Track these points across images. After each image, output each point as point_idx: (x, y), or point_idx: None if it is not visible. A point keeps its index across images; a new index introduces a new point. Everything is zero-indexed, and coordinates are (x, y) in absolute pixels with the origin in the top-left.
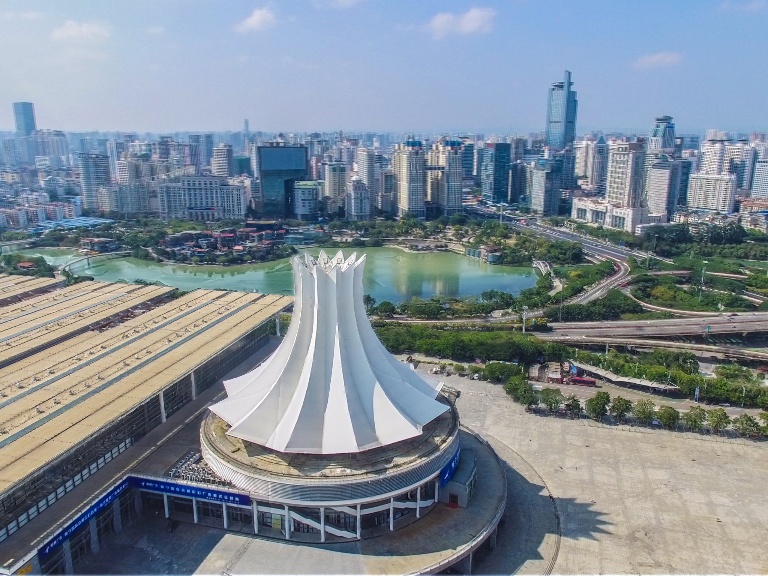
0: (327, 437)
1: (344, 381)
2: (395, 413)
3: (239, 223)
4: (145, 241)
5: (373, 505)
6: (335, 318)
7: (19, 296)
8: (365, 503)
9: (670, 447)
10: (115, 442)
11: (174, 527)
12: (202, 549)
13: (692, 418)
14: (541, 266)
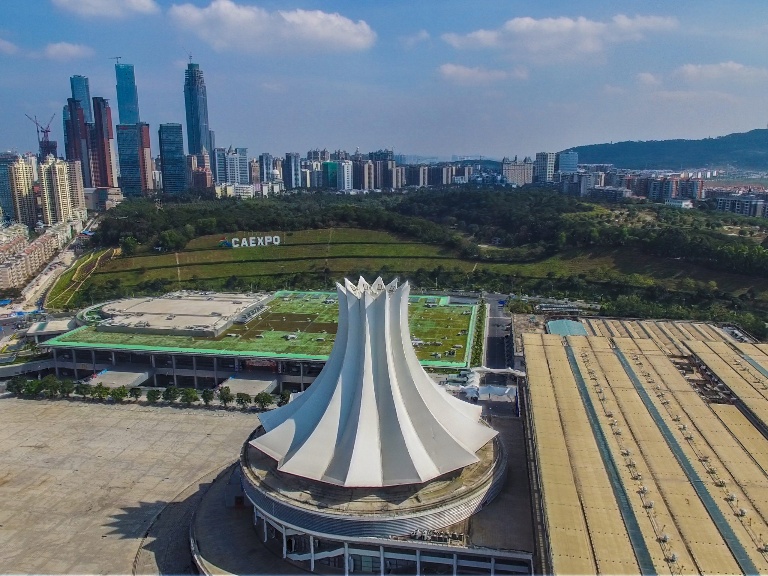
0: None
1: None
2: None
3: None
4: None
5: None
6: None
7: None
8: None
9: None
10: None
11: None
12: None
13: None
14: None
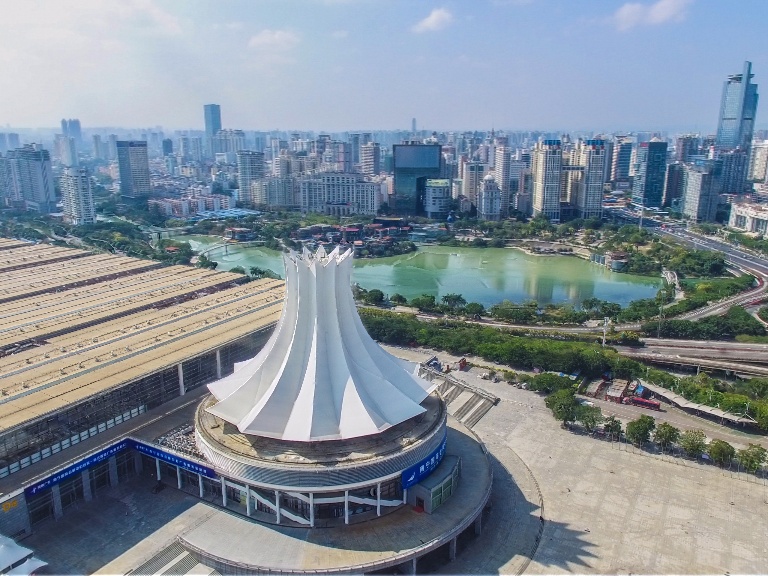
0: (291, 424)
1: (316, 372)
2: (361, 409)
3: (370, 219)
4: (279, 232)
5: (327, 496)
6: (315, 311)
7: (117, 274)
8: (314, 492)
9: (710, 486)
10: (130, 407)
11: (159, 489)
12: (172, 512)
13: (749, 457)
14: (668, 276)
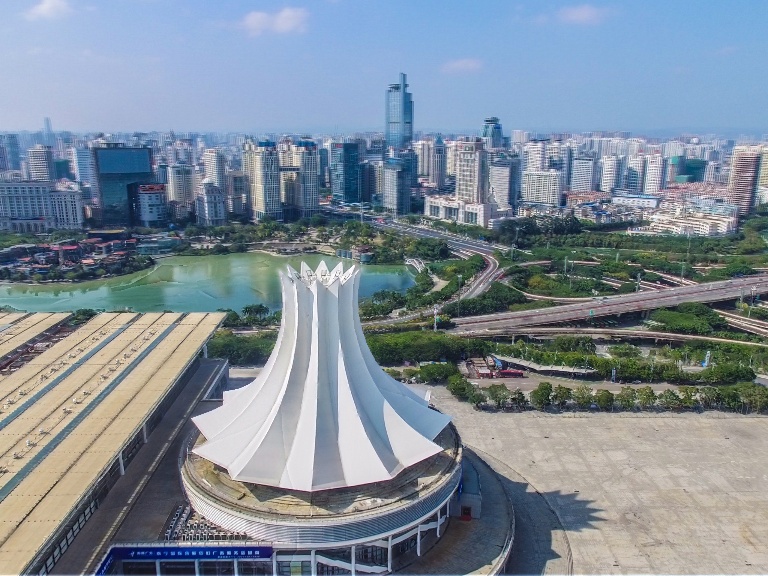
0: (348, 467)
1: (355, 403)
2: (410, 431)
3: (77, 233)
4: None
5: (402, 533)
6: (337, 336)
7: None
8: (399, 532)
9: (615, 428)
10: None
11: None
12: None
13: (625, 398)
14: (416, 263)
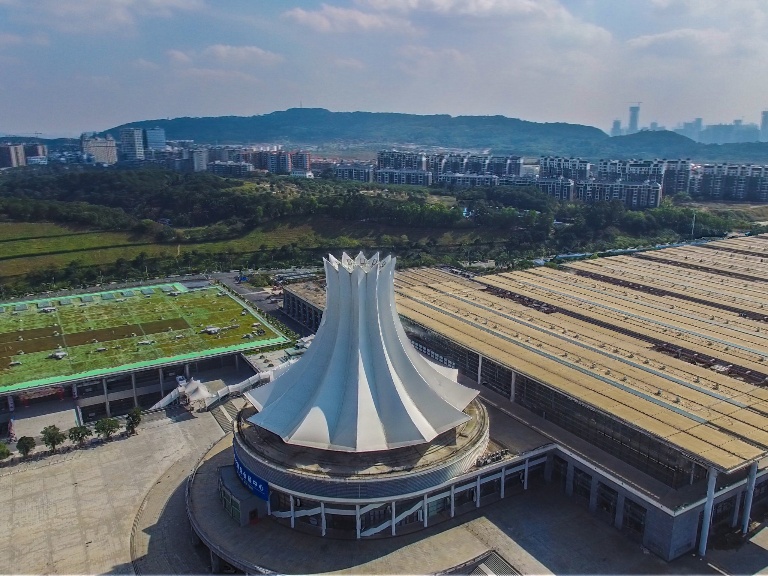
0: None
1: None
2: None
3: None
4: None
5: None
6: None
7: None
8: None
9: None
10: None
11: None
12: None
13: None
14: None
